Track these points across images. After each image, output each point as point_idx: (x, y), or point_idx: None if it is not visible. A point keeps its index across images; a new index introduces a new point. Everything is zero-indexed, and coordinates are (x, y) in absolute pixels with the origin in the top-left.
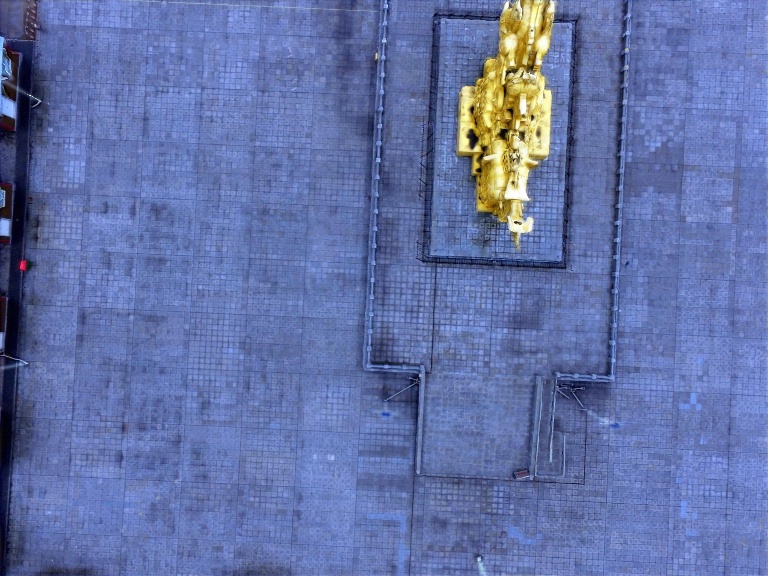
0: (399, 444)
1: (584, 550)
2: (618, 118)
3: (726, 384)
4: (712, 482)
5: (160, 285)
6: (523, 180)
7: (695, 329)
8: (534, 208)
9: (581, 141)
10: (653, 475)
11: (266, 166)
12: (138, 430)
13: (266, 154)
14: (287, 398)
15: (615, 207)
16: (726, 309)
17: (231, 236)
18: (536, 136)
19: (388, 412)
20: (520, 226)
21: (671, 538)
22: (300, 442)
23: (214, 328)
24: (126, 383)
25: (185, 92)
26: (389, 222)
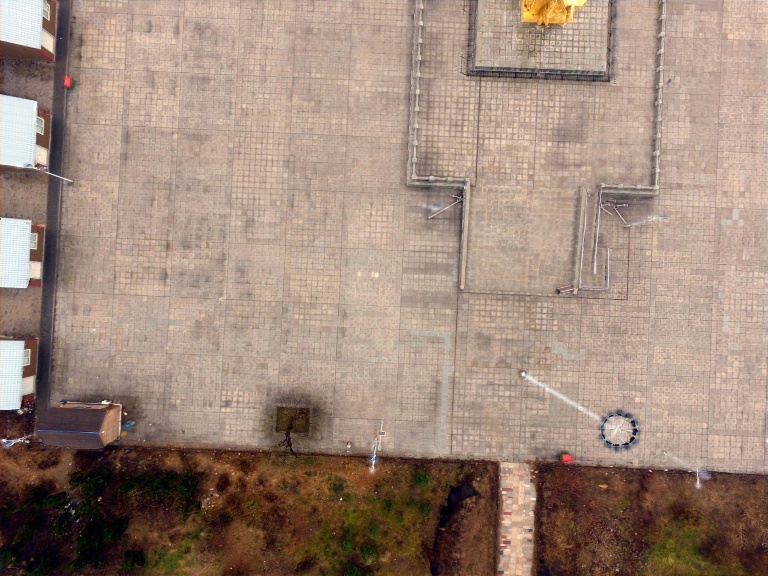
0: (443, 261)
1: (627, 365)
2: None
3: (767, 200)
4: (754, 297)
5: (204, 104)
6: None
7: (737, 145)
8: (578, 19)
9: None
10: (696, 290)
11: None
12: (182, 248)
13: None
14: (331, 216)
15: (658, 20)
16: (767, 125)
17: (275, 55)
18: None
19: (432, 229)
20: None
21: (714, 352)
22: (344, 260)
23: (258, 147)
24: (170, 201)
25: None
26: (433, 36)
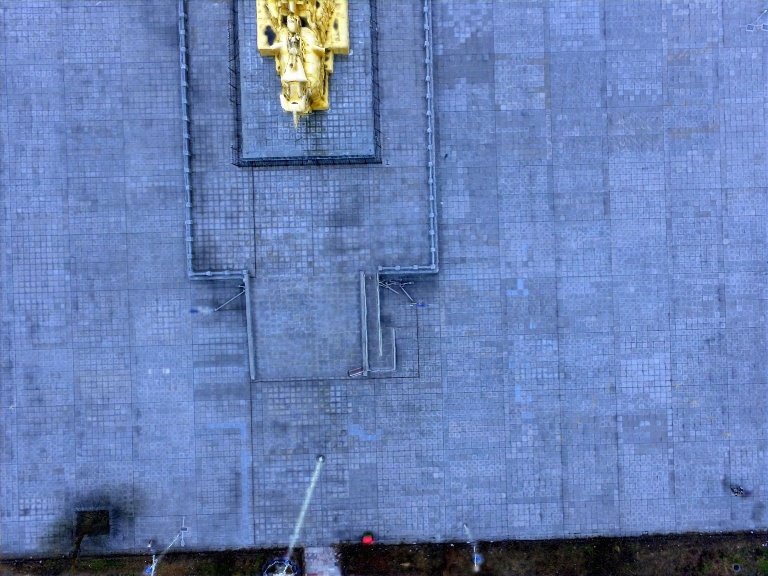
0: (233, 352)
1: (423, 441)
2: (422, 9)
3: (551, 267)
4: (544, 364)
5: None
6: (311, 67)
7: (517, 216)
8: (343, 104)
9: (388, 35)
10: (486, 362)
11: (77, 83)
12: None
13: (76, 71)
14: (117, 315)
15: (426, 98)
16: (546, 194)
17: (47, 157)
18: (334, 28)
19: (220, 321)
20: (296, 105)
21: (508, 422)
22: (134, 358)
23: (37, 251)
24: None
25: None
26: (202, 129)
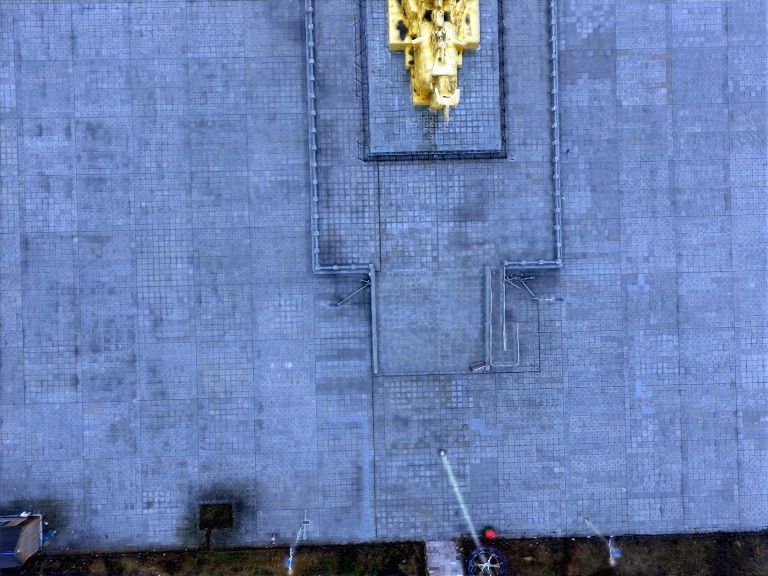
0: (355, 346)
1: (544, 436)
2: (548, 4)
3: (672, 263)
4: (664, 360)
5: (102, 205)
6: (452, 61)
7: (638, 211)
8: (470, 98)
9: (513, 30)
10: (607, 357)
11: (201, 78)
12: (91, 352)
13: (200, 65)
14: (240, 309)
15: (551, 93)
16: (667, 189)
17: (171, 151)
18: (466, 23)
19: (342, 316)
20: (448, 99)
21: (628, 417)
22: (256, 352)
23: (161, 245)
24: (75, 306)
25: (112, 7)
26: (328, 124)
